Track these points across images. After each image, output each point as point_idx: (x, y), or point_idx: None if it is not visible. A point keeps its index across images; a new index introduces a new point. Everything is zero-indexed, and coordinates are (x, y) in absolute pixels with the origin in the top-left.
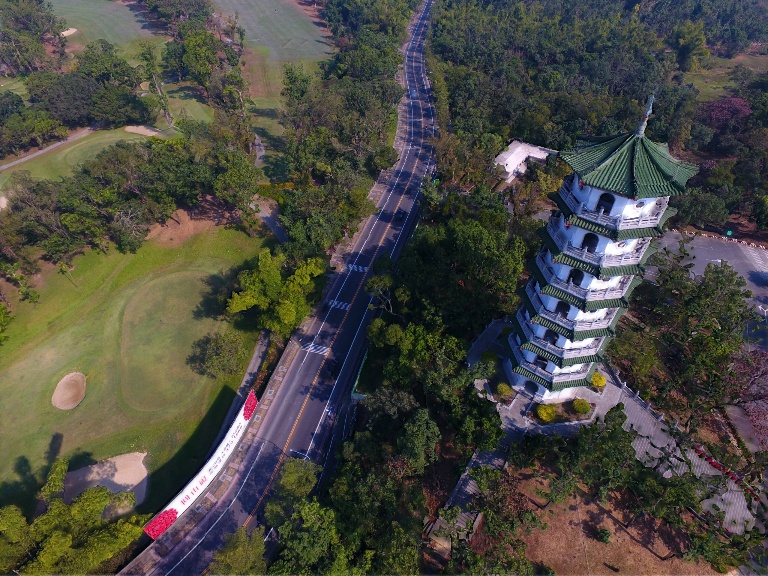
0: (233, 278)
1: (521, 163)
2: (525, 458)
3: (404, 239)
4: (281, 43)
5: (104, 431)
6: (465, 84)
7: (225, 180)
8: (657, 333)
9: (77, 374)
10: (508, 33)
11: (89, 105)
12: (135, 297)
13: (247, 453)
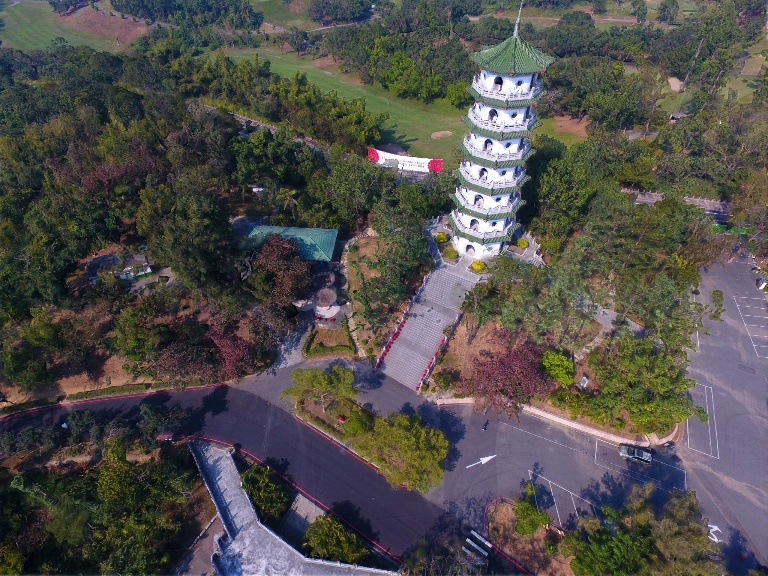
0: None
1: None
2: None
3: None
4: None
5: (421, 147)
6: None
7: None
8: None
9: None
10: None
11: None
12: None
13: (413, 177)
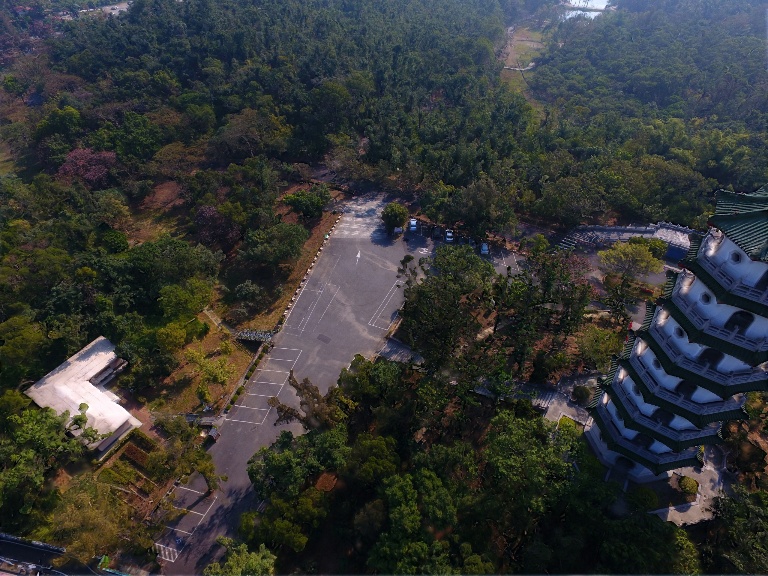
0: None
1: None
2: (765, 476)
3: None
4: None
5: None
6: None
7: None
8: None
9: None
10: None
11: None
12: None
13: None
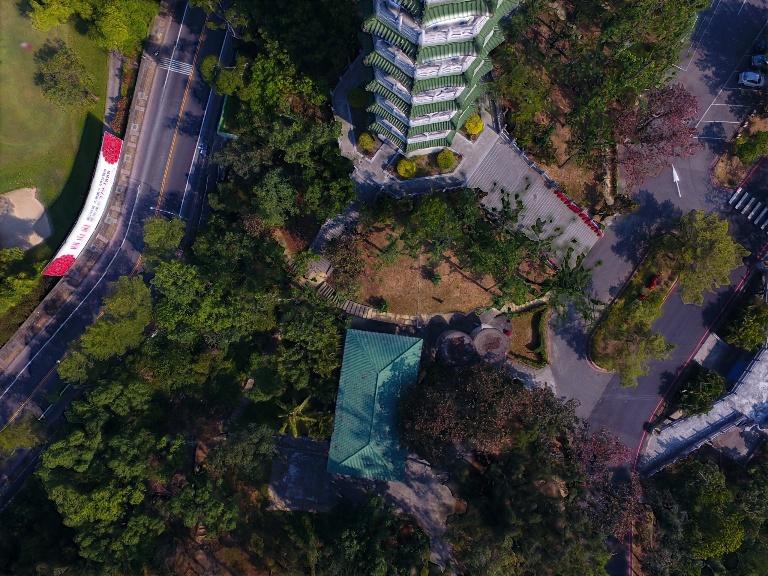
0: None
1: None
2: (374, 218)
3: None
4: None
5: None
6: None
7: None
8: None
9: None
10: None
11: None
12: None
13: (125, 196)
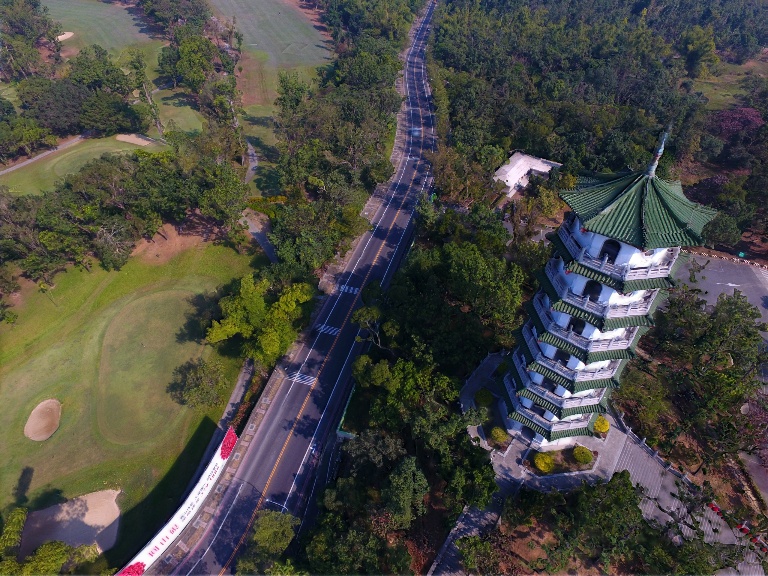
0: (218, 300)
1: (523, 176)
2: (520, 516)
3: (399, 258)
4: (280, 48)
5: (76, 466)
6: (466, 93)
7: (211, 197)
8: (665, 373)
9: (52, 401)
10: (512, 38)
11: (80, 113)
12: (117, 318)
13: (224, 496)
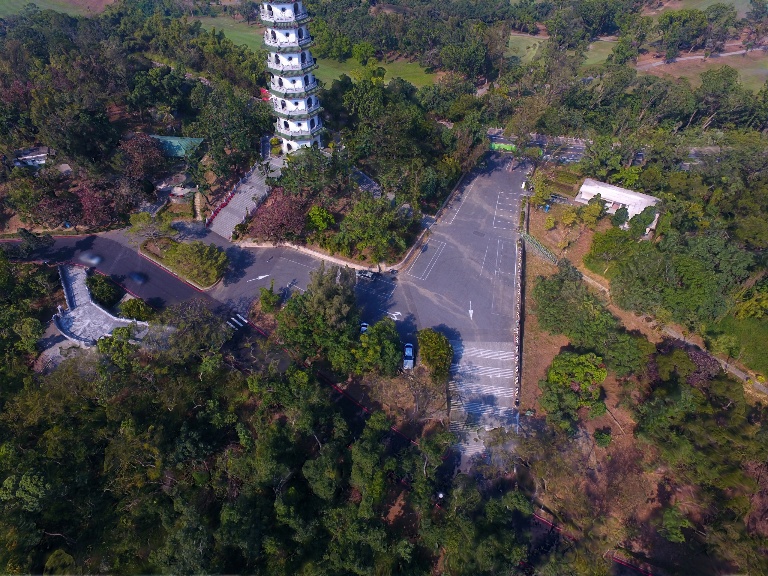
0: None
1: None
2: None
3: None
4: None
5: None
6: None
7: None
8: None
9: None
10: None
11: None
12: None
13: None
